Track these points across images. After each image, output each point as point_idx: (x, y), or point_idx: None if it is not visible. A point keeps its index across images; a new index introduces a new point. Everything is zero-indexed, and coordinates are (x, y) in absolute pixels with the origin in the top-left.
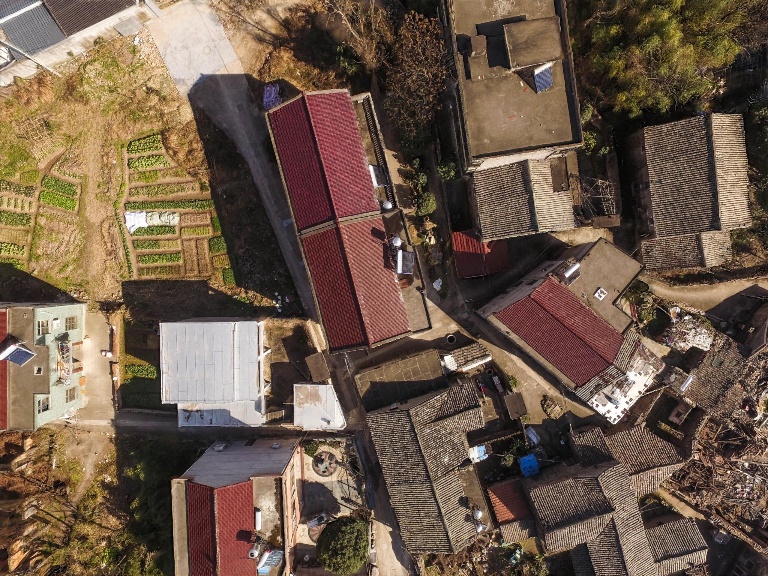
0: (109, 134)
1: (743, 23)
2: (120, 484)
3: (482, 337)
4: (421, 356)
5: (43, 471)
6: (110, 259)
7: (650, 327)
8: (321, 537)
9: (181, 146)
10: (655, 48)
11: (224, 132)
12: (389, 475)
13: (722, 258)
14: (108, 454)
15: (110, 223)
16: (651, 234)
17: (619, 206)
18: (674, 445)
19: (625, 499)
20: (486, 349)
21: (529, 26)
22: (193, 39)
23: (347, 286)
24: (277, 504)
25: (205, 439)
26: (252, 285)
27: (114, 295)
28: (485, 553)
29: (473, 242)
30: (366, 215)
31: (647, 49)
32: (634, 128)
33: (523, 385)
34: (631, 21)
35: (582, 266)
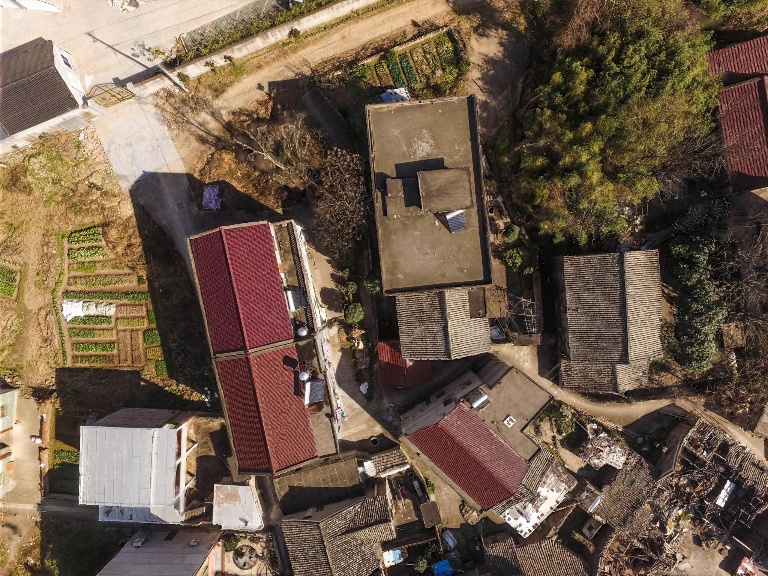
0: (50, 225)
1: (662, 163)
2: (43, 568)
3: None
4: (339, 463)
5: None
6: (45, 346)
7: (569, 439)
8: None
9: (120, 240)
10: (570, 192)
11: (163, 229)
12: None
13: (636, 382)
14: (33, 537)
15: (47, 311)
16: (568, 357)
17: (540, 325)
18: (583, 560)
19: None
20: (405, 457)
21: (442, 175)
22: (137, 137)
23: (255, 414)
24: None
25: (129, 527)
26: (183, 379)
27: (47, 381)
28: None
29: (396, 354)
30: (278, 344)
31: (567, 185)
32: (558, 251)
33: (443, 489)
34: (555, 155)
35: (493, 393)
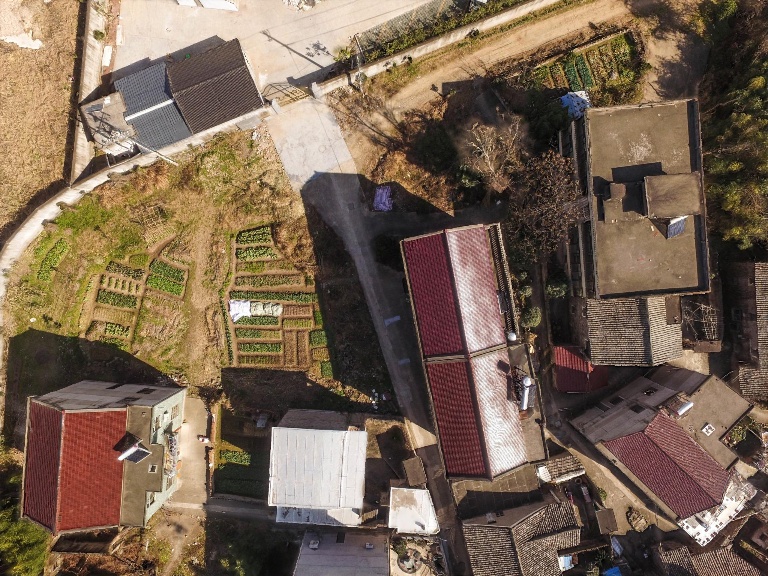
0: (220, 224)
1: None
2: (207, 567)
3: (573, 446)
4: None
5: (134, 551)
6: (212, 345)
7: (739, 448)
8: None
9: (290, 240)
10: None
11: (333, 229)
12: None
13: None
14: (197, 537)
15: (215, 310)
16: (753, 365)
17: (721, 332)
18: (759, 569)
19: None
20: (580, 463)
21: (670, 180)
22: (310, 137)
23: (472, 418)
24: None
25: (294, 529)
26: (350, 381)
27: (214, 381)
28: None
29: (576, 359)
30: (494, 349)
31: (767, 191)
32: (741, 257)
33: (610, 496)
34: (751, 160)
35: (692, 401)
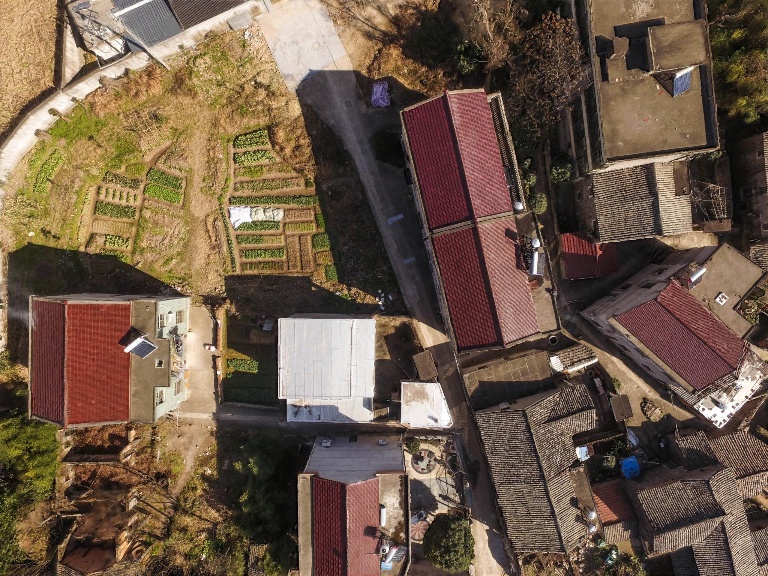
0: (216, 128)
1: None
2: (220, 477)
3: (584, 339)
4: (530, 356)
5: (145, 462)
6: (214, 253)
7: (752, 332)
8: (429, 534)
9: (288, 142)
10: None
11: (331, 128)
12: (498, 474)
13: None
14: (209, 447)
15: (215, 217)
16: (764, 239)
17: (730, 211)
18: None
19: (733, 503)
20: (592, 351)
21: (674, 29)
22: (303, 34)
23: (482, 286)
24: (401, 501)
25: (306, 434)
26: (355, 282)
27: (217, 289)
28: (582, 553)
29: (584, 244)
30: (501, 216)
31: None
32: (748, 133)
33: (623, 387)
34: (756, 25)
35: None
